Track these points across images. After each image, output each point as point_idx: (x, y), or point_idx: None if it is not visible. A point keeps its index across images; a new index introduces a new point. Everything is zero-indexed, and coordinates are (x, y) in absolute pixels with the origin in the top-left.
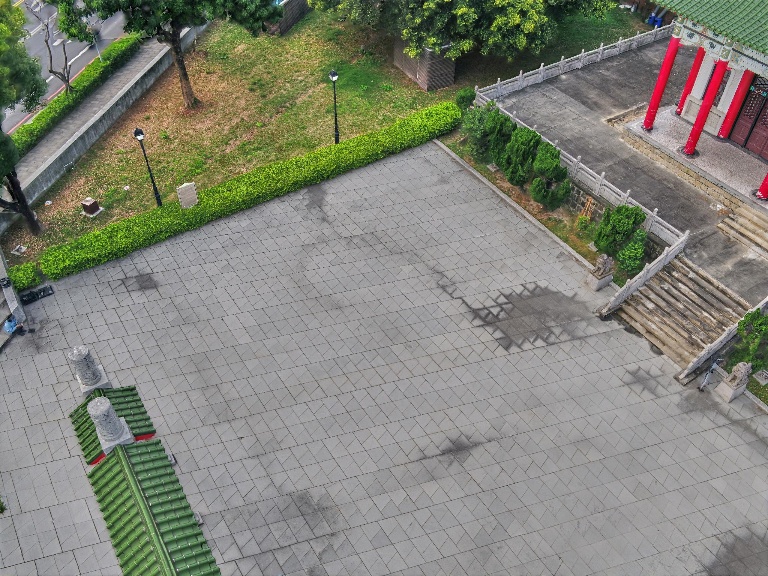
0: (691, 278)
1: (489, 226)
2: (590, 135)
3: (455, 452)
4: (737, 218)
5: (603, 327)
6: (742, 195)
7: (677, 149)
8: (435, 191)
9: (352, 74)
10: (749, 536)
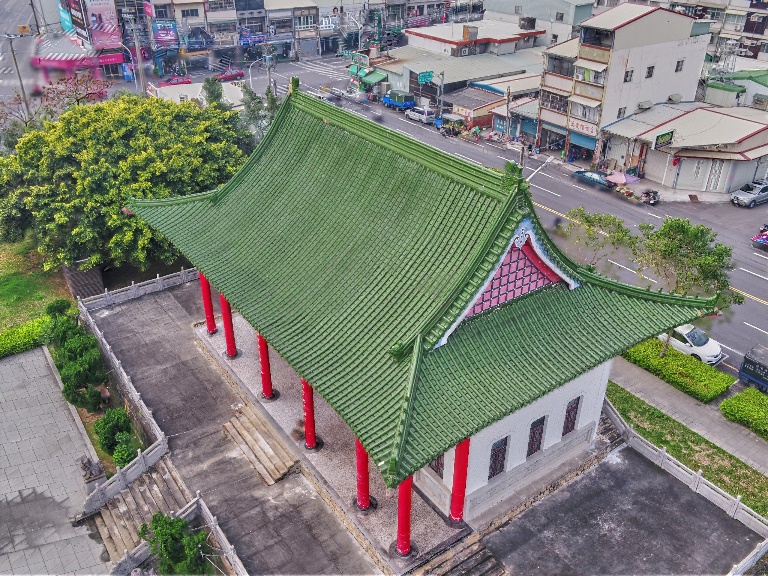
0: (164, 479)
1: (32, 431)
2: (169, 339)
3: None
4: (240, 417)
5: (69, 533)
6: (251, 394)
7: (224, 351)
8: (5, 397)
9: (13, 285)
10: None
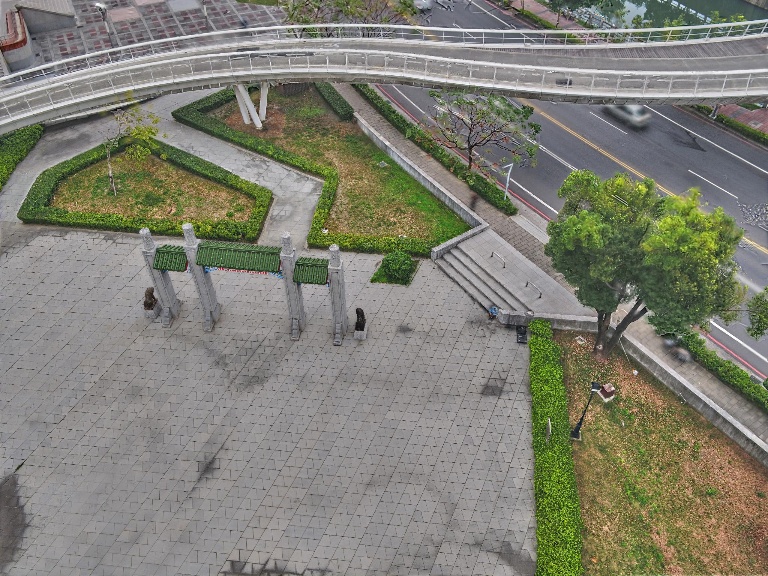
0: None
1: None
2: None
3: (208, 465)
4: None
5: None
6: None
7: None
8: None
9: None
10: (4, 568)
